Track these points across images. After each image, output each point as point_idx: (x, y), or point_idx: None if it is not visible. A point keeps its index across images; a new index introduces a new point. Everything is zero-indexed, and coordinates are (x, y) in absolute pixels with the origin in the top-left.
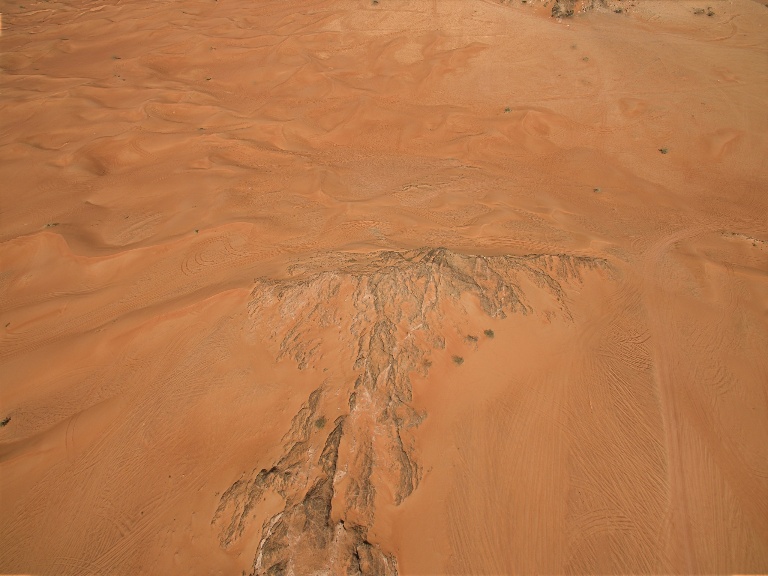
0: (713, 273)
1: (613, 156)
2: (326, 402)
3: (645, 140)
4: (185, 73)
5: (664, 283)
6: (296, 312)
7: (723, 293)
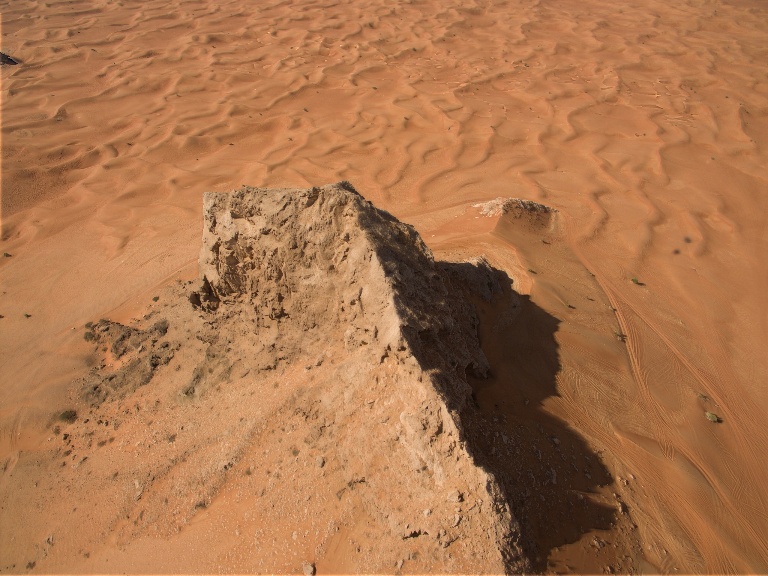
0: None
1: None
2: None
3: None
4: (260, 136)
5: None
6: None
7: None
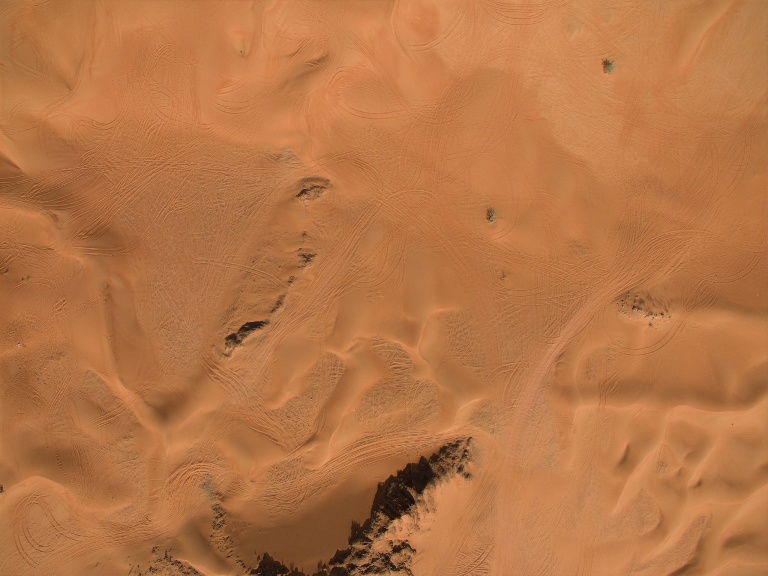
0: (581, 418)
1: (530, 89)
2: None
3: (586, 37)
4: None
5: (524, 458)
6: None
7: (582, 450)
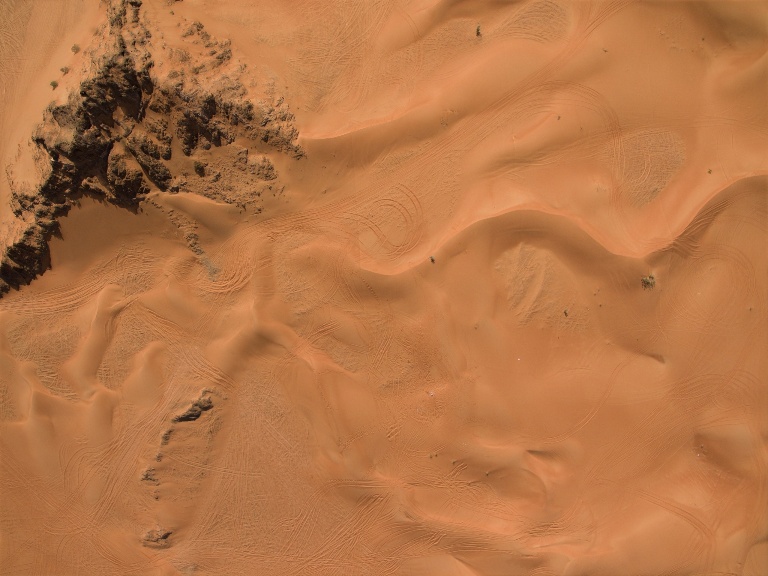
0: None
1: None
2: None
3: None
4: None
5: None
6: (222, 76)
7: None
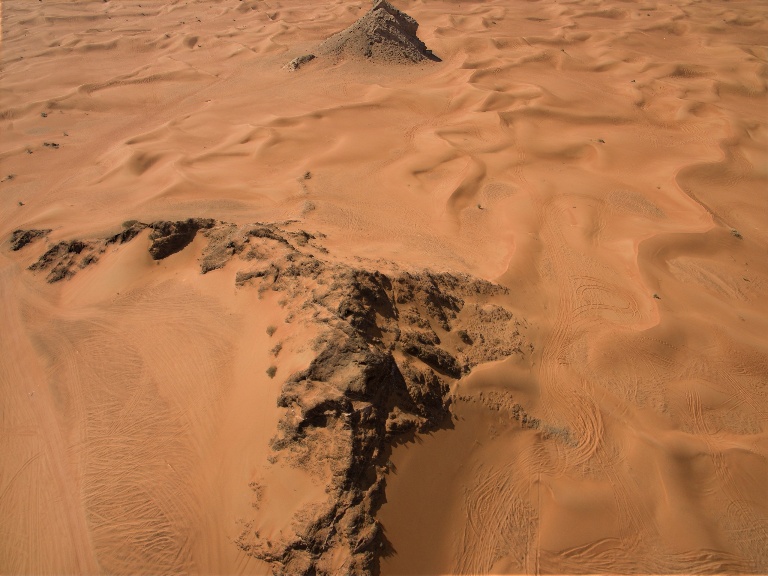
0: None
1: None
2: (312, 249)
3: None
4: None
5: None
6: (410, 267)
7: None
